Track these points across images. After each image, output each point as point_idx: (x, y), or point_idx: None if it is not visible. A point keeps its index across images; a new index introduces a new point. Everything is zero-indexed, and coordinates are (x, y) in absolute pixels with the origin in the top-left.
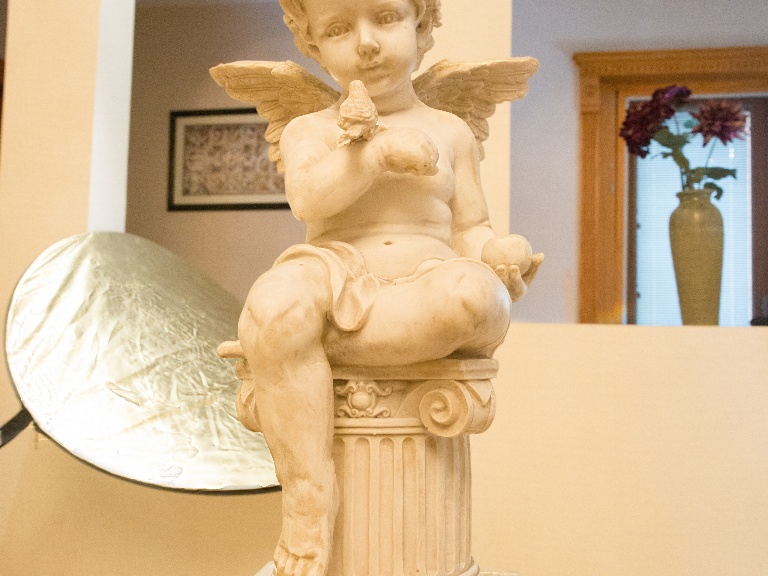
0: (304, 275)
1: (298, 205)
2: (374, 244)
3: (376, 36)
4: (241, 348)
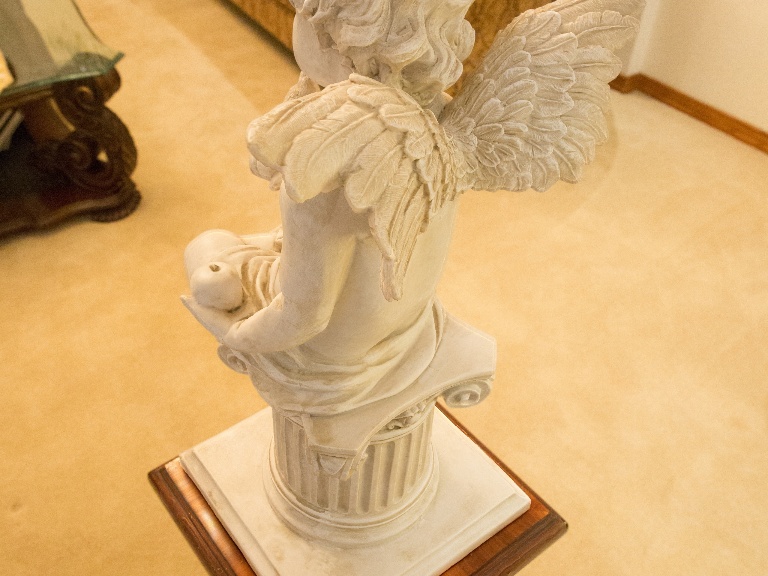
0: None
1: None
2: None
3: None
4: None
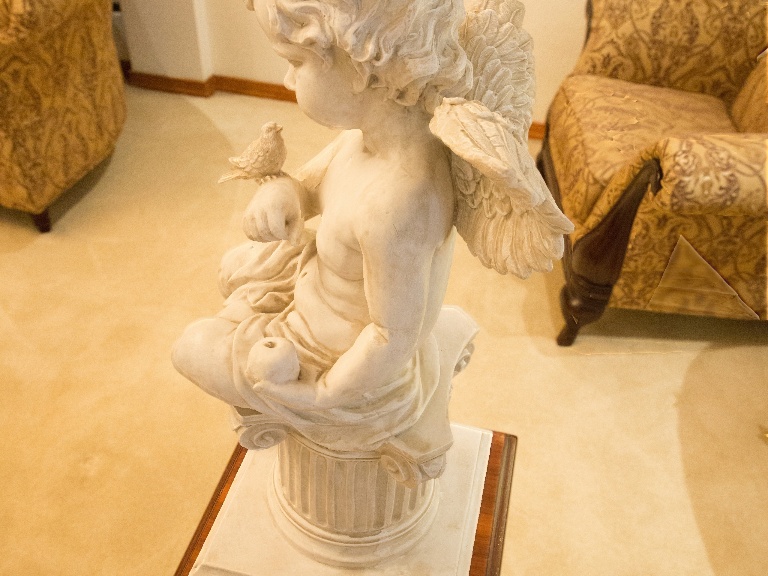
0: (239, 256)
1: None
2: (305, 267)
3: (295, 76)
4: None
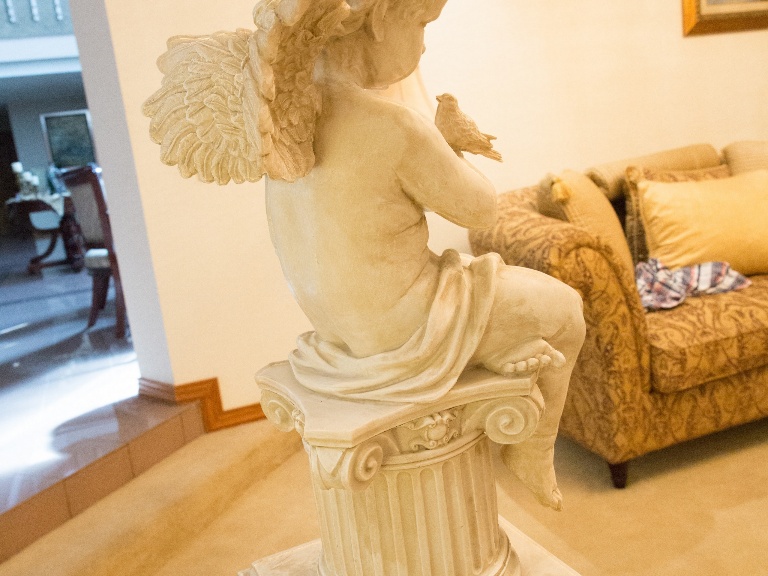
0: None
1: None
2: None
3: None
4: None
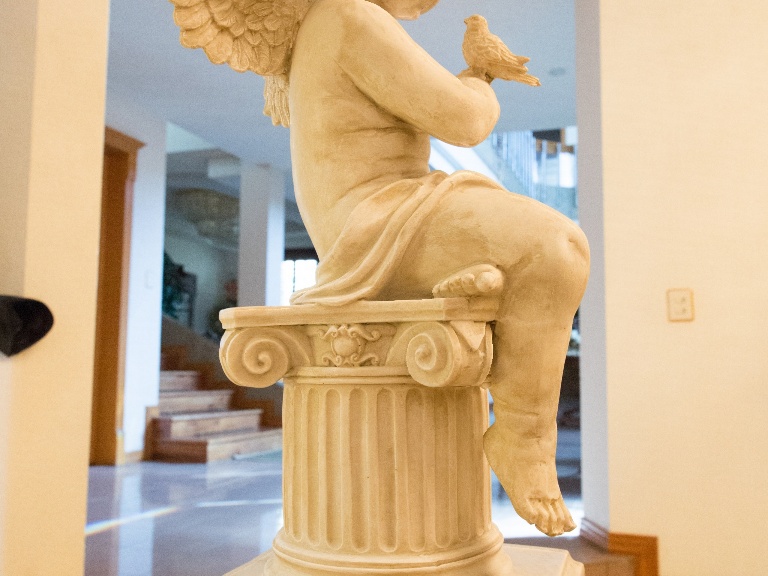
0: None
1: (481, 128)
2: None
3: None
4: (499, 282)
